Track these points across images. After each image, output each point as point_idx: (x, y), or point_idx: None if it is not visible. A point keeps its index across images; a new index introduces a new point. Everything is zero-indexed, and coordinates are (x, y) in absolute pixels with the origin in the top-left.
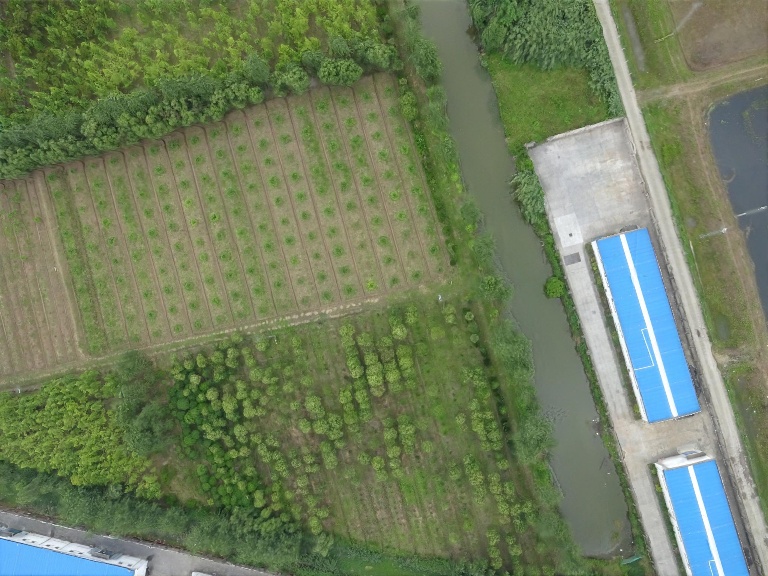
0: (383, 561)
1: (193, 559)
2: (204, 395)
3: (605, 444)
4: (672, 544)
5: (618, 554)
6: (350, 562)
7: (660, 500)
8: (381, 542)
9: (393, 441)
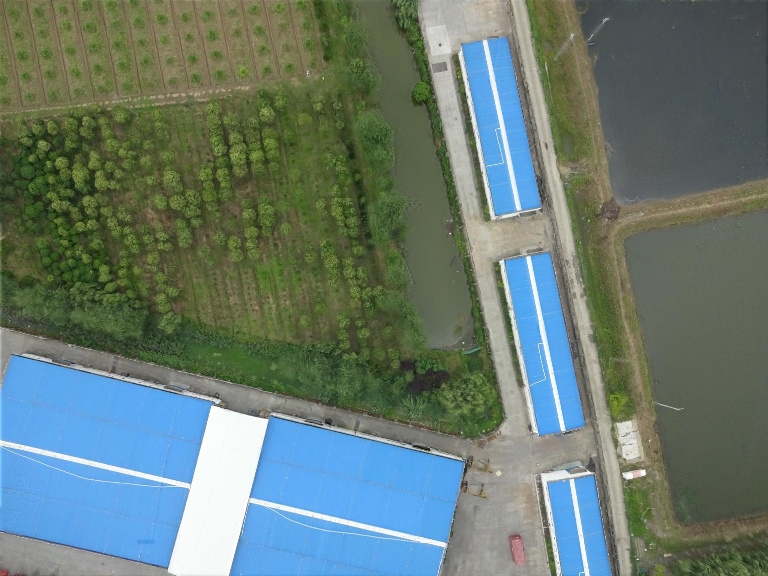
0: (232, 348)
1: (25, 340)
2: (52, 163)
3: (456, 243)
4: (509, 336)
5: (460, 346)
6: (198, 348)
7: (501, 295)
8: (232, 328)
9: (251, 221)
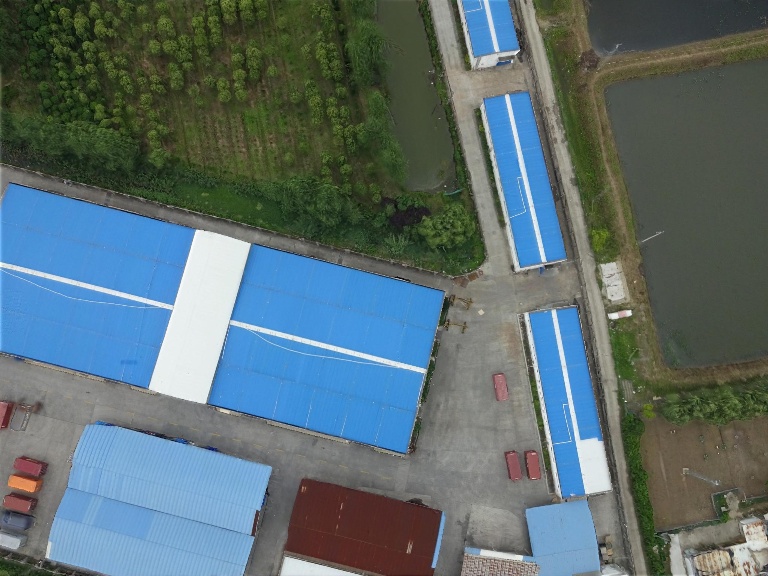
0: (220, 188)
1: (24, 178)
2: (56, 13)
3: (438, 92)
4: (490, 178)
5: (442, 189)
6: (187, 188)
7: (482, 139)
8: (220, 169)
9: (239, 64)
